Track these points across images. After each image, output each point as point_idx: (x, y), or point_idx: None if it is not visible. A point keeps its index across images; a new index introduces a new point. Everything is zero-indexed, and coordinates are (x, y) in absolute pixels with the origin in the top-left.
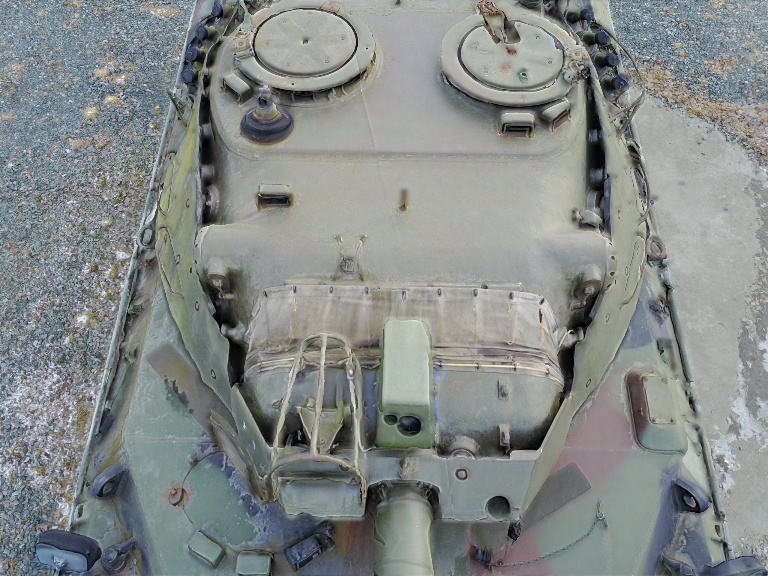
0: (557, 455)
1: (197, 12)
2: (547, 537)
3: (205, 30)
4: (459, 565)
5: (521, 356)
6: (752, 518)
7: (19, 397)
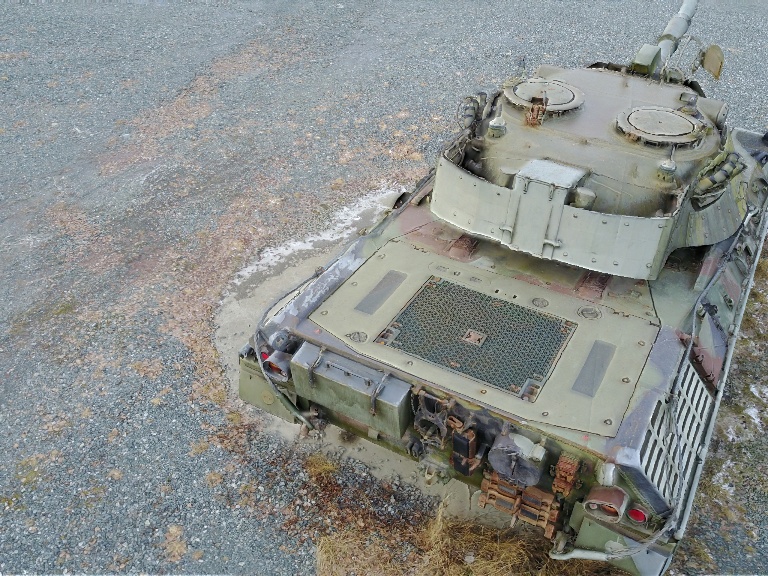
0: None
1: None
2: None
3: None
4: None
5: None
6: None
7: None
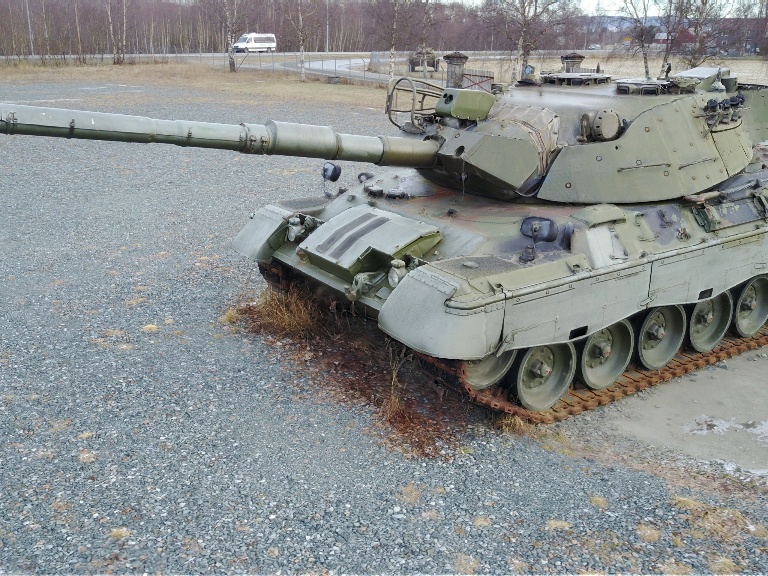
0: (515, 180)
1: None
2: None
3: None
4: None
5: None
6: (693, 447)
7: None
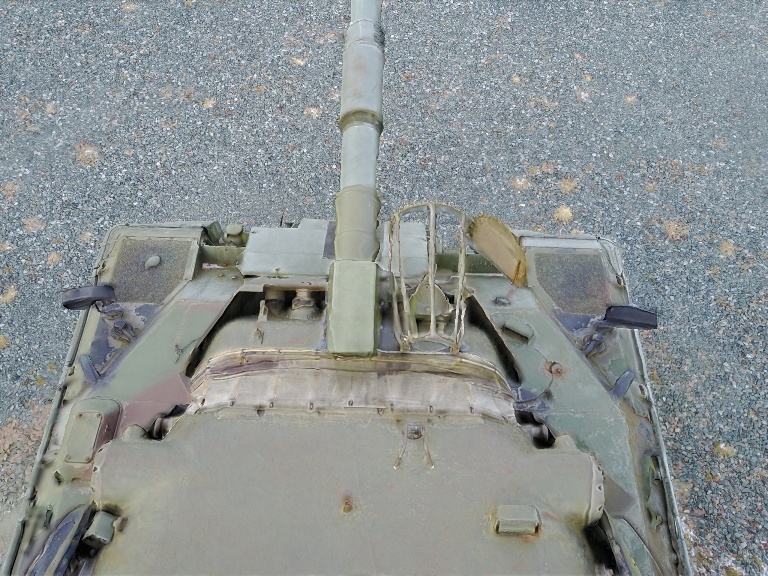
0: None
1: None
2: None
3: None
4: None
5: (234, 368)
6: None
7: None
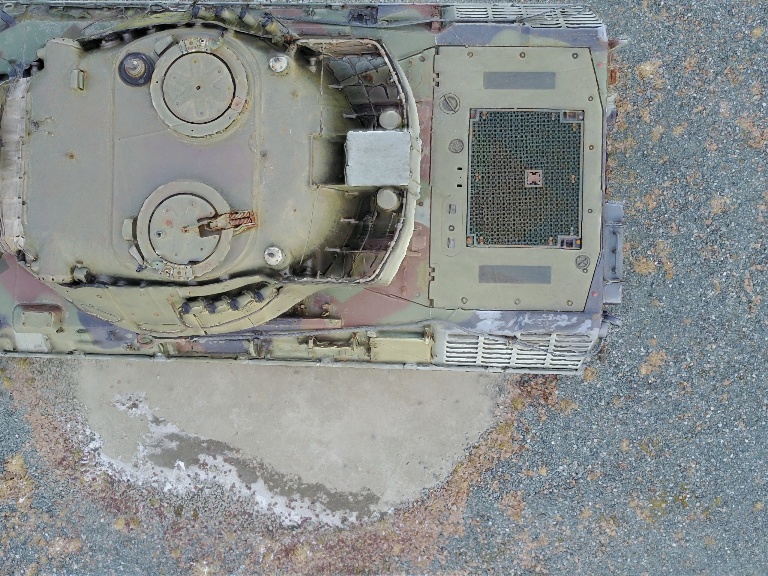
0: None
1: (415, 7)
2: None
3: (242, 17)
4: None
5: None
6: (98, 415)
7: None
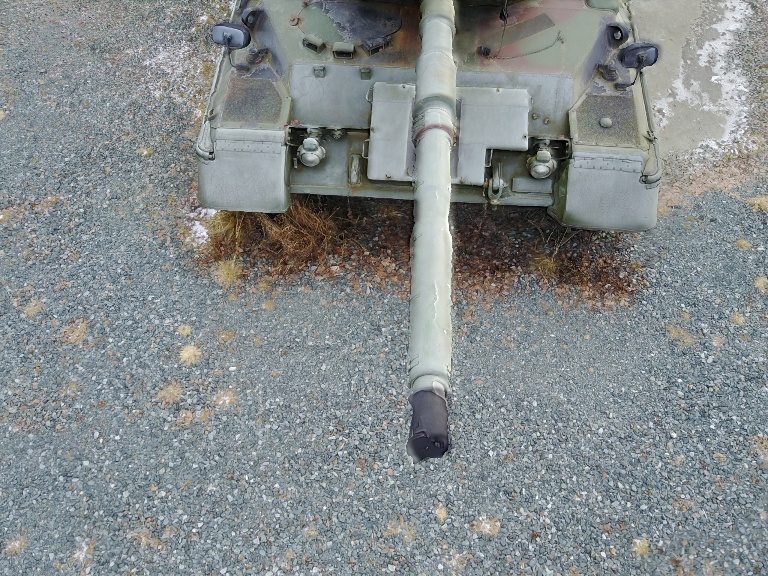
0: None
1: None
2: (525, 47)
3: None
4: (470, 58)
5: None
6: (679, 141)
7: (162, 58)
